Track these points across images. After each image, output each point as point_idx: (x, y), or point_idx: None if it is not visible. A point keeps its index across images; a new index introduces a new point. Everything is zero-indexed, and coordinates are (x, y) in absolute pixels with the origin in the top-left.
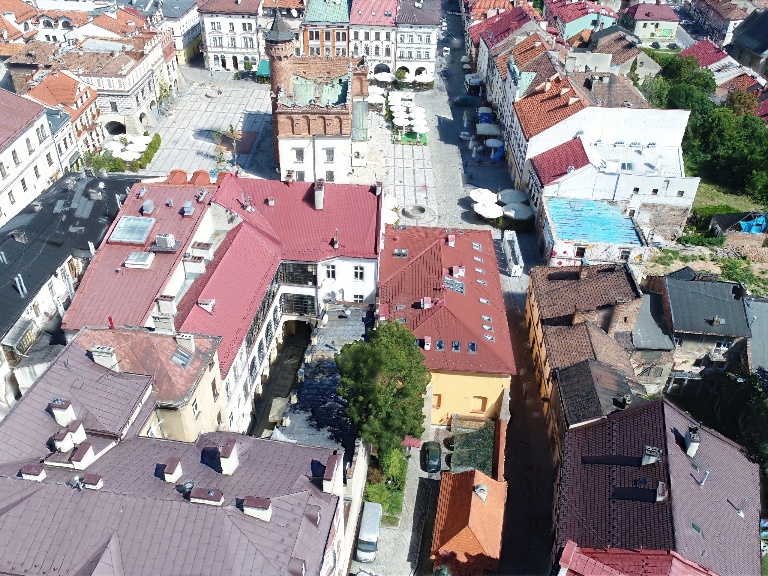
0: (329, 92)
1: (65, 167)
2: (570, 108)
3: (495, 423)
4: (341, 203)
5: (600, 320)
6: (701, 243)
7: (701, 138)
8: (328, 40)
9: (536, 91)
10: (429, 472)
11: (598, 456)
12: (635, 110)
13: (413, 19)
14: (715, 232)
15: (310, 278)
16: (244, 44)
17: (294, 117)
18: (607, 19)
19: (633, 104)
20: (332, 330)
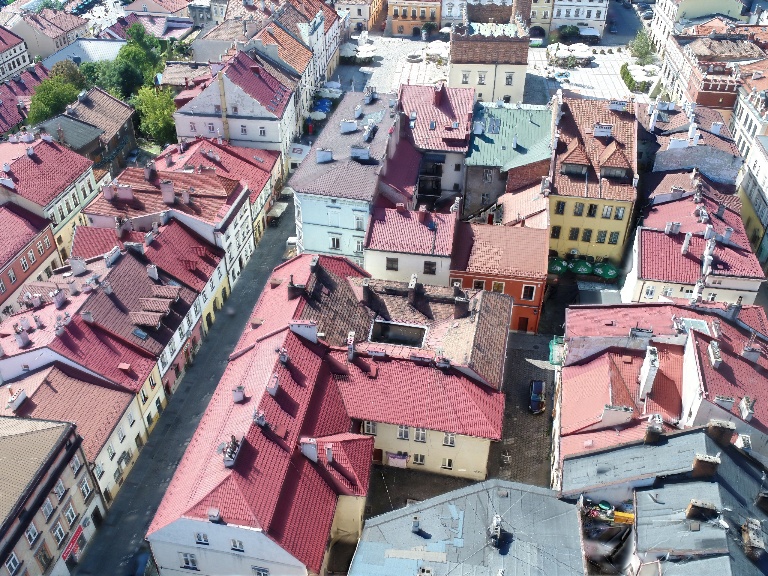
0: None
1: None
2: None
3: None
4: None
5: None
6: None
7: None
8: None
9: None
10: None
11: None
12: None
13: None
14: None
15: None
16: None
17: (505, 14)
18: None
19: None
20: None
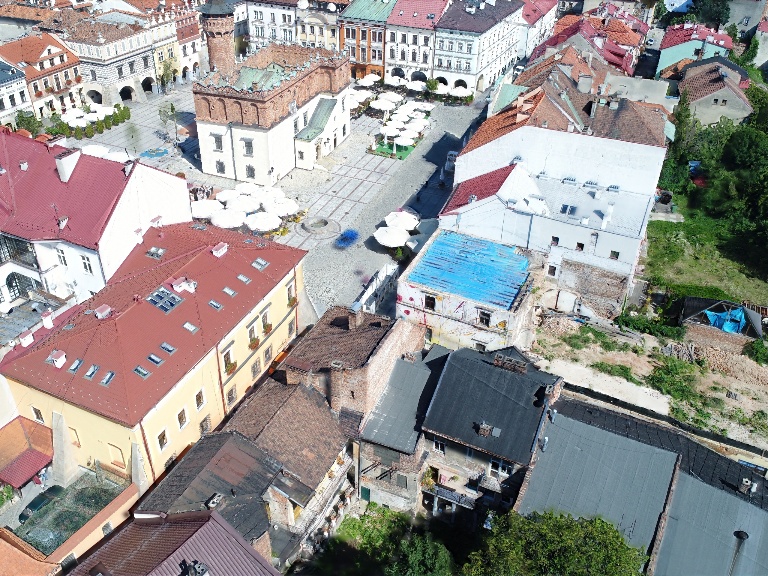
0: (275, 80)
1: (7, 123)
2: (514, 126)
3: (129, 485)
4: (89, 179)
5: (323, 387)
6: (648, 330)
7: (748, 200)
8: (364, 39)
9: (512, 107)
10: (22, 523)
11: (104, 567)
12: (589, 137)
13: (455, 24)
14: (679, 320)
15: (33, 259)
16: (284, 36)
17: (210, 99)
18: (715, 49)
19: (641, 139)
20: (9, 322)
